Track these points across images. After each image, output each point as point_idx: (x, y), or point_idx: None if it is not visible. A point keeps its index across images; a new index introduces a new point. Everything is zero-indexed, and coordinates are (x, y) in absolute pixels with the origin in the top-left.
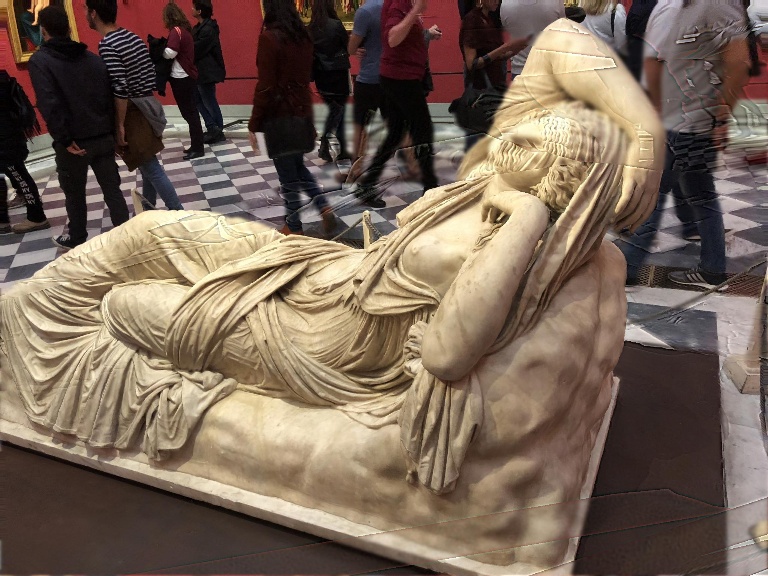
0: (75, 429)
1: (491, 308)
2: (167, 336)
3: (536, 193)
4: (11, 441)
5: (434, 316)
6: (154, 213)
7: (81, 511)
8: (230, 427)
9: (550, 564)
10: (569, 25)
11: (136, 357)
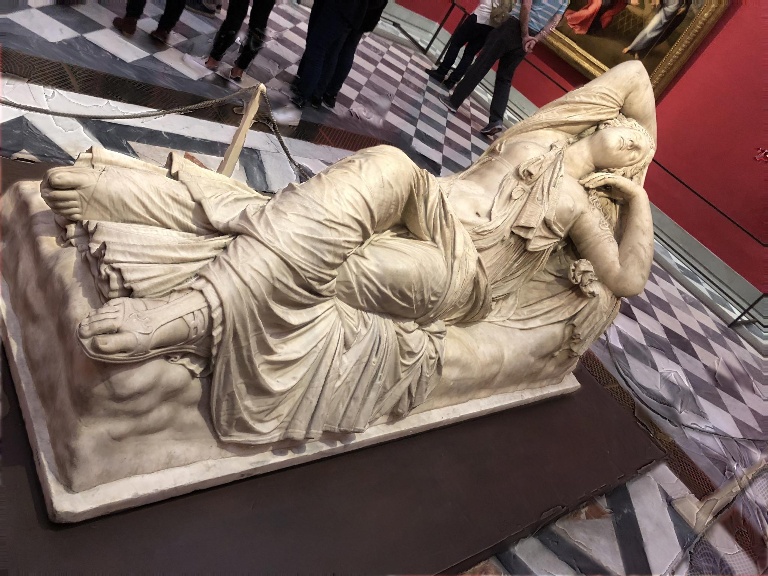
0: None
1: None
2: (448, 300)
3: (607, 171)
4: (200, 488)
5: (634, 264)
6: None
7: (371, 496)
8: (458, 362)
9: None
10: None
11: None
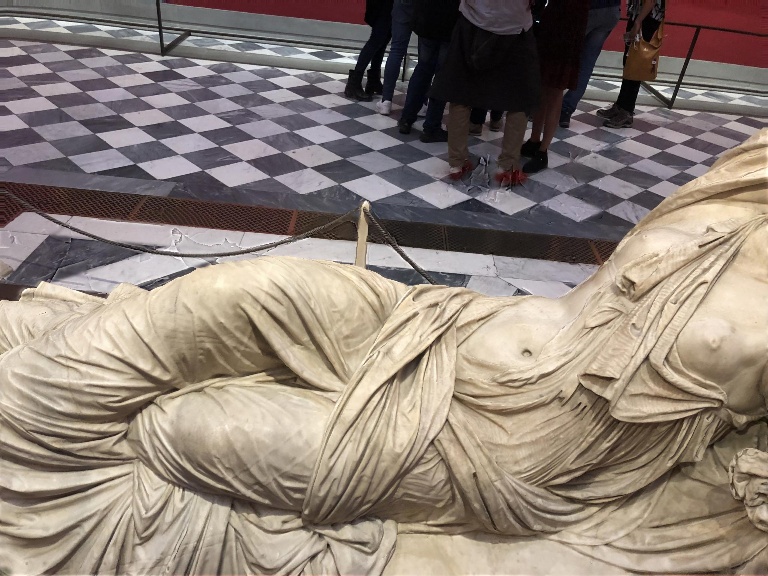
0: None
1: None
2: (319, 490)
3: None
4: None
5: None
6: (232, 272)
7: None
8: None
9: None
10: None
11: (236, 519)
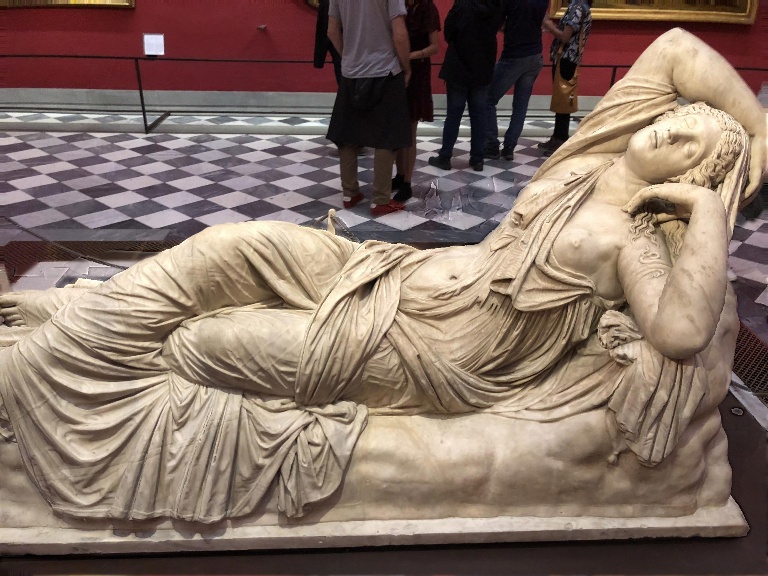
0: (159, 510)
1: (725, 288)
2: (305, 370)
3: None
4: (34, 552)
5: (672, 302)
6: (230, 227)
7: None
8: (389, 456)
9: (725, 501)
10: (691, 35)
11: (247, 402)
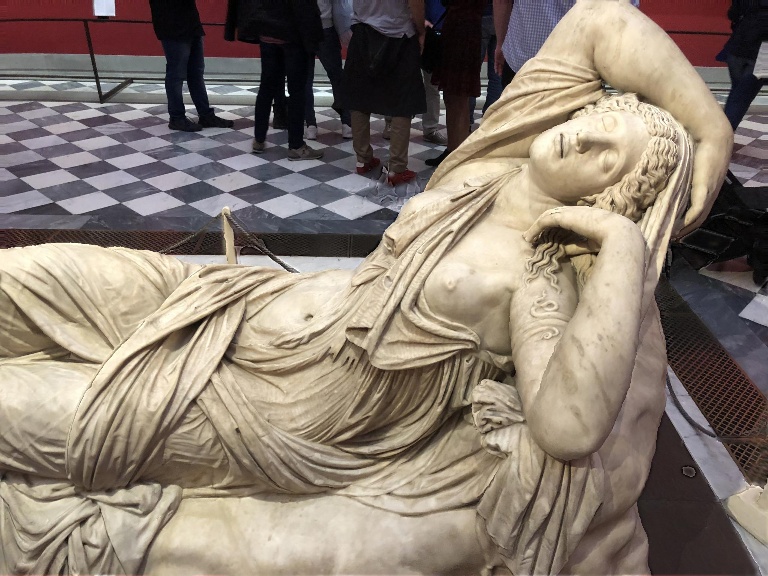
0: None
1: (629, 366)
2: (73, 452)
3: (586, 204)
4: None
5: (554, 384)
6: None
7: None
8: (196, 559)
9: None
10: (618, 1)
11: (5, 489)
